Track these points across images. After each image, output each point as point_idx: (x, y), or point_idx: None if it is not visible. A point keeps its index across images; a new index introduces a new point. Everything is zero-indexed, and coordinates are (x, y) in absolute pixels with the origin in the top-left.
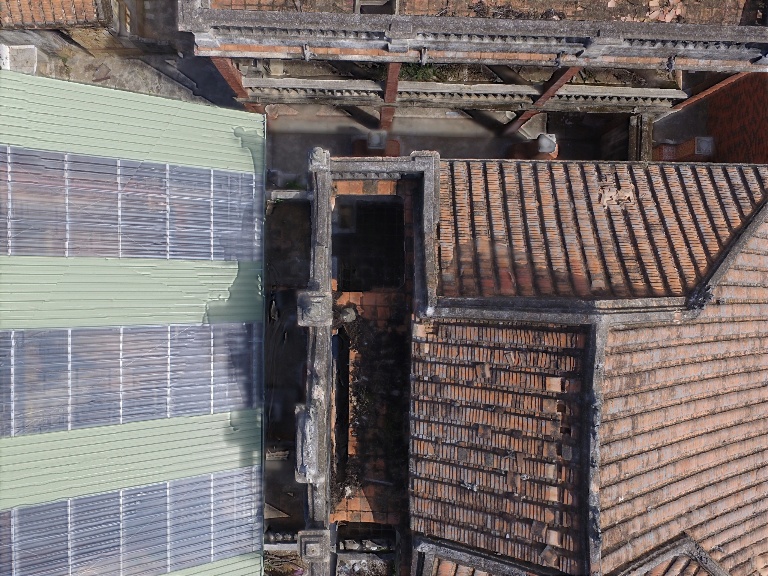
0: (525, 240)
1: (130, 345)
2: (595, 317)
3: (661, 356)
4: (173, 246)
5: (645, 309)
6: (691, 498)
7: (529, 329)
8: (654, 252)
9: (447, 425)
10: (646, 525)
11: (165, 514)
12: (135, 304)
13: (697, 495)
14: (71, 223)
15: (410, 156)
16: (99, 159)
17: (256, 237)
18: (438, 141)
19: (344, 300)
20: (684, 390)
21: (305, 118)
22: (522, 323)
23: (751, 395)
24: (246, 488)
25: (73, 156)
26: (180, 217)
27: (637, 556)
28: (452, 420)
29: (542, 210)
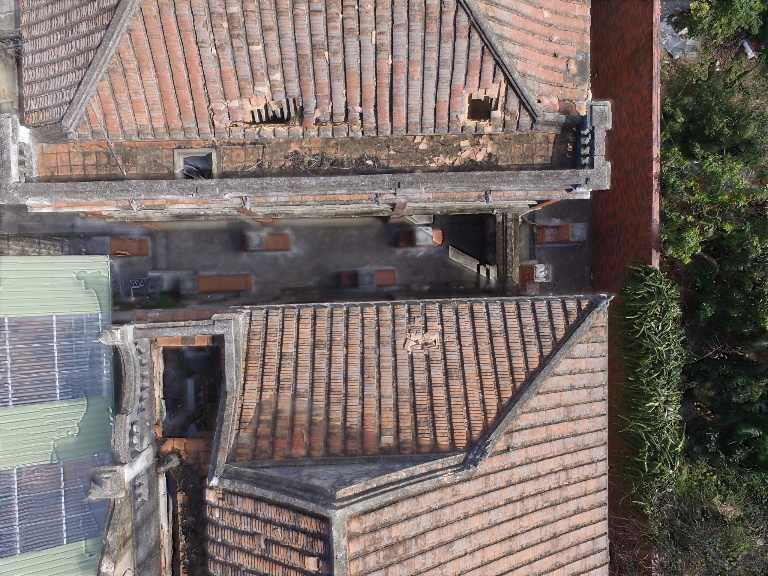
0: (327, 392)
1: None
2: (330, 512)
3: (432, 519)
4: (16, 392)
5: (406, 482)
6: None
7: (290, 509)
8: (448, 401)
9: None
10: None
11: None
12: None
13: None
14: None
15: (211, 319)
16: None
17: (105, 371)
18: (328, 230)
19: (169, 446)
20: (467, 542)
21: None
22: None
23: (558, 527)
24: None
25: None
26: (22, 364)
27: None
28: None
29: (347, 359)
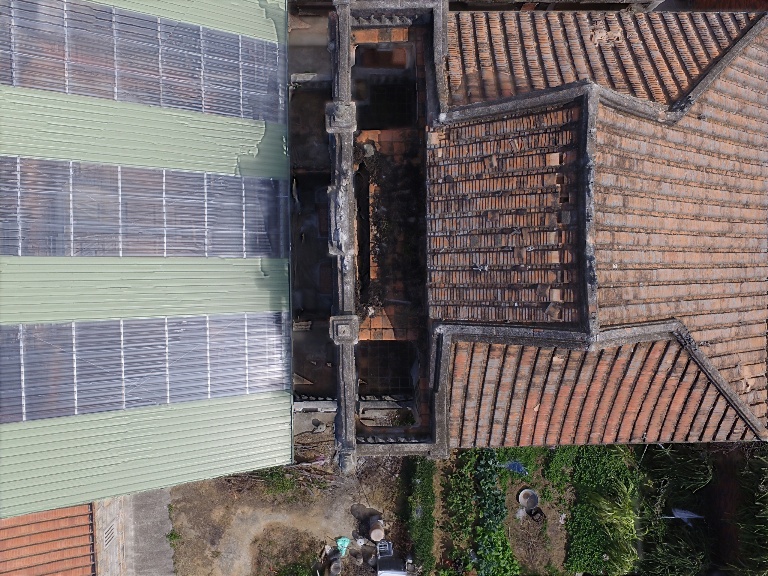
0: (525, 71)
1: (172, 187)
2: (587, 87)
3: (648, 149)
4: (207, 101)
5: None
6: (679, 288)
7: (530, 115)
8: (641, 77)
9: (460, 218)
10: (638, 297)
11: (205, 344)
12: (175, 150)
13: (685, 288)
14: (119, 70)
15: None
16: (142, 15)
17: (280, 101)
18: None
19: (363, 138)
20: (670, 188)
21: (317, 31)
22: (524, 113)
23: (733, 212)
24: (276, 330)
25: (120, 10)
26: (213, 75)
27: (631, 322)
28: (464, 213)
29: (539, 48)
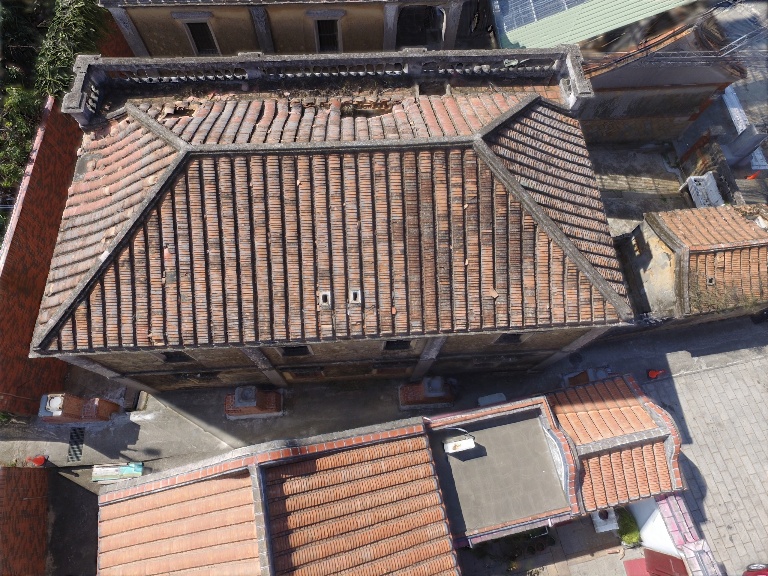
0: None
1: None
2: None
3: None
4: None
5: None
6: None
7: None
8: None
9: None
10: None
11: None
12: None
13: None
14: None
15: None
16: None
17: (497, 2)
18: None
19: None
20: None
21: None
22: None
23: None
24: None
25: None
26: None
27: None
28: None
29: None
